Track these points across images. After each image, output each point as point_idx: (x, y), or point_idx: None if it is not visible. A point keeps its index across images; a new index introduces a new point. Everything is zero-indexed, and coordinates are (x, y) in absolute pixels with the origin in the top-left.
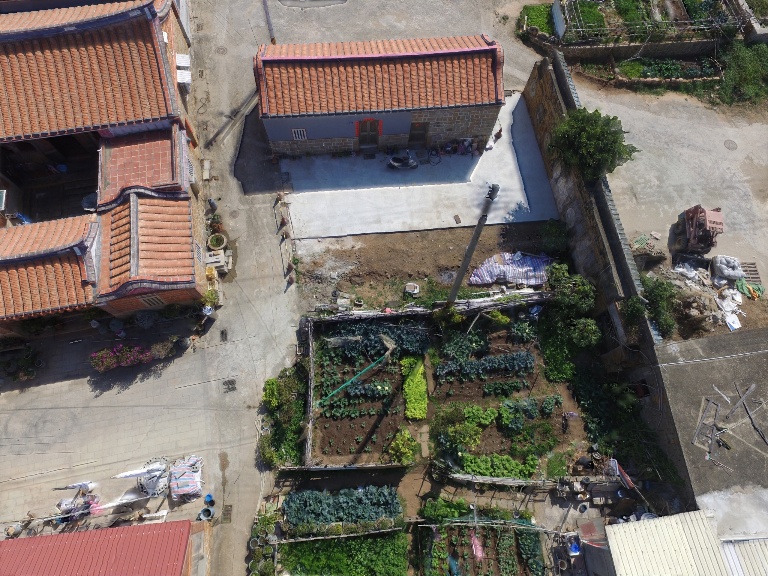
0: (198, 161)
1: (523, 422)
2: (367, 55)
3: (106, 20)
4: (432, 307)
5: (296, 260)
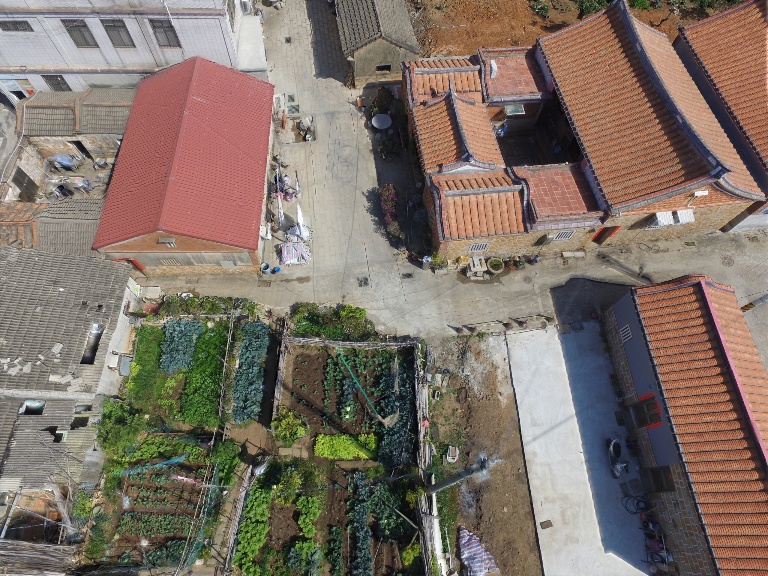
0: (581, 246)
1: (296, 570)
2: (746, 400)
3: (697, 141)
4: (428, 472)
5: (482, 335)
